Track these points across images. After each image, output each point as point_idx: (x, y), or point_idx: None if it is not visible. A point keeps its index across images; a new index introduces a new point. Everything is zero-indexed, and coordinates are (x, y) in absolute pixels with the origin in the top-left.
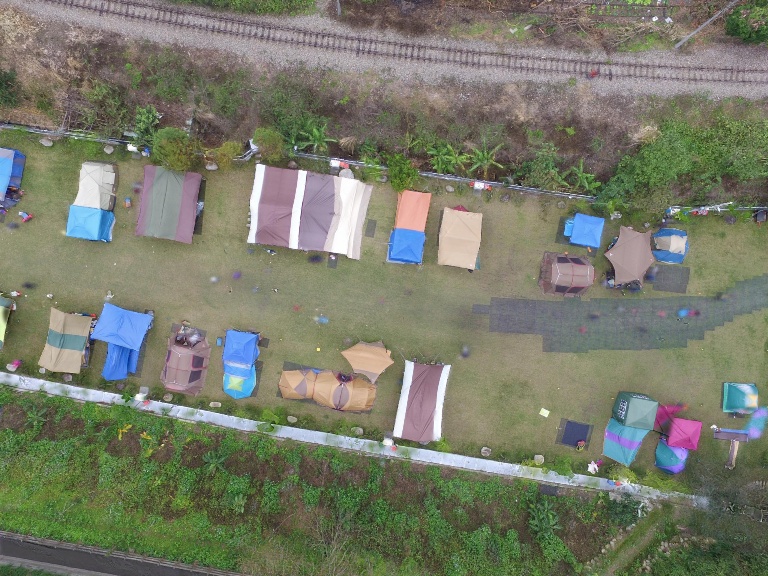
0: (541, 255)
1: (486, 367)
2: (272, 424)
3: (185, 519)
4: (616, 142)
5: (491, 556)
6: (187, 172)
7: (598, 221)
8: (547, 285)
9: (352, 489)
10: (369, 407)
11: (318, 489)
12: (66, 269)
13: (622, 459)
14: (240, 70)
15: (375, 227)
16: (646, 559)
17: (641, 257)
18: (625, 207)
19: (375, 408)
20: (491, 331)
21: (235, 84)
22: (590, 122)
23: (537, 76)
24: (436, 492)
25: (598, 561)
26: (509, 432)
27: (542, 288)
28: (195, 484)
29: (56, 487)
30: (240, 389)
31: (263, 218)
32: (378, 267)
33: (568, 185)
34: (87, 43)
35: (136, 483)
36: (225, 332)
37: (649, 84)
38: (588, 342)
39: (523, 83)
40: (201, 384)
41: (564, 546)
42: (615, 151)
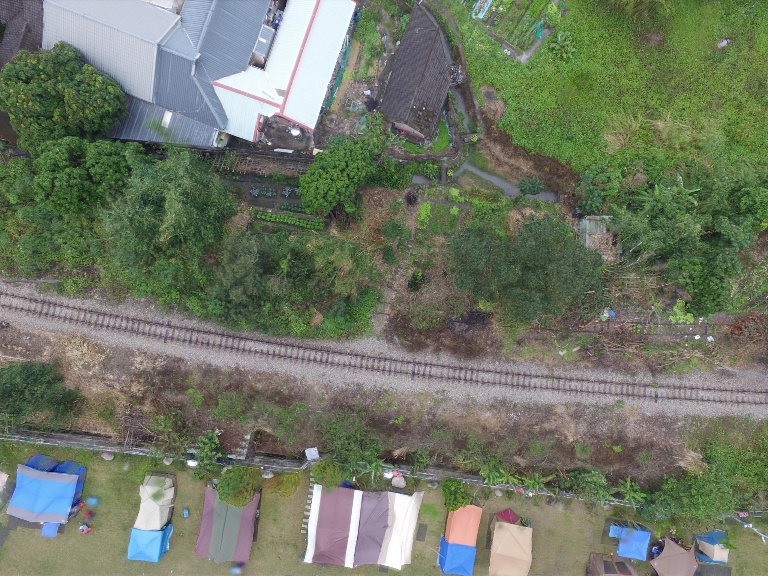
0: (587, 556)
1: None
2: None
3: None
4: (661, 458)
5: None
6: None
7: (645, 537)
8: None
9: None
10: None
11: None
12: None
13: None
14: (299, 392)
15: (426, 531)
16: None
17: (686, 571)
18: (672, 529)
19: None
20: None
21: (294, 406)
22: (636, 441)
23: (586, 398)
24: None
25: None
26: None
27: None
28: None
29: None
30: None
31: (321, 543)
32: (429, 570)
33: (615, 500)
34: (152, 370)
35: None
36: None
37: (693, 406)
38: None
39: (572, 405)
40: None
41: None
42: (660, 465)
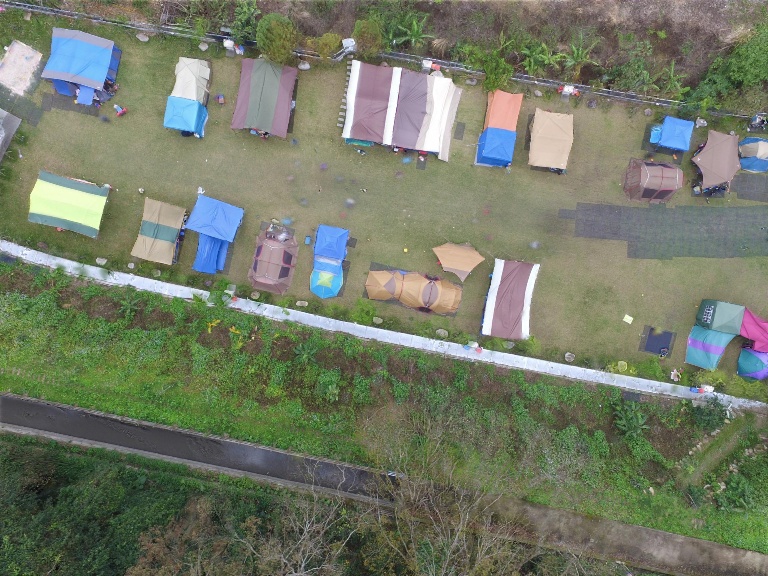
0: (627, 161)
1: (571, 272)
2: (358, 324)
3: (280, 406)
4: (706, 47)
5: (581, 452)
6: (285, 65)
7: (688, 124)
8: (634, 189)
9: (440, 387)
10: (454, 310)
11: (408, 384)
12: (158, 164)
13: (707, 365)
14: None
15: (464, 130)
16: (732, 463)
17: (730, 160)
18: (717, 108)
19: (460, 311)
20: (577, 236)
21: None
22: (681, 26)
23: None
24: (521, 394)
25: (686, 462)
26: (593, 338)
27: (628, 194)
28: (287, 375)
29: (152, 371)
30: (329, 285)
31: (359, 111)
32: (466, 170)
33: (658, 88)
34: None
35: (230, 371)
36: (313, 231)
37: None
38: (672, 249)
39: None
40: (288, 283)
41: (652, 447)
42: (704, 56)
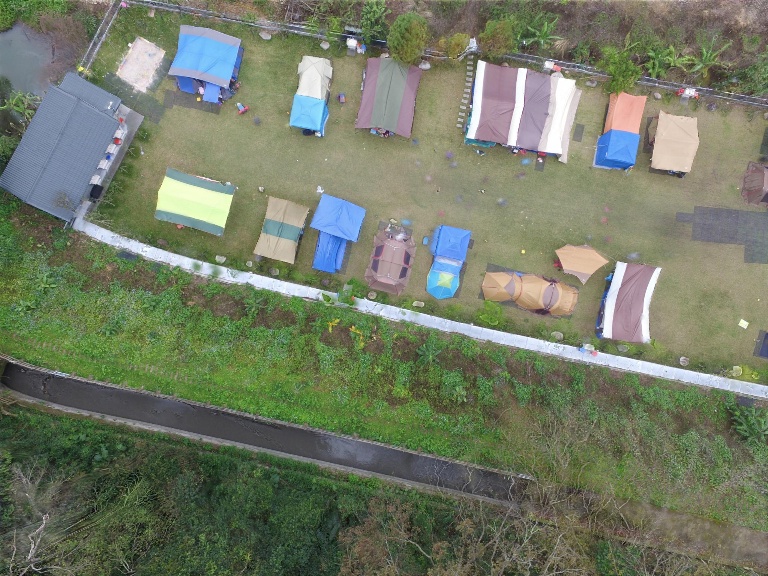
0: (745, 165)
1: (687, 276)
2: (473, 326)
3: (408, 406)
4: None
5: (706, 457)
6: (411, 65)
7: None
8: (755, 193)
9: (560, 389)
10: (570, 312)
11: (530, 386)
12: (278, 163)
13: None
14: None
15: (583, 132)
16: None
17: None
18: None
19: (575, 314)
20: (694, 240)
21: None
22: None
23: None
24: (638, 398)
25: None
26: (707, 342)
27: (746, 198)
28: (411, 375)
29: (281, 370)
30: (450, 286)
31: (486, 112)
32: (584, 172)
33: None
34: None
35: (357, 370)
36: (431, 231)
37: None
38: None
39: None
40: (405, 283)
41: None
42: None
